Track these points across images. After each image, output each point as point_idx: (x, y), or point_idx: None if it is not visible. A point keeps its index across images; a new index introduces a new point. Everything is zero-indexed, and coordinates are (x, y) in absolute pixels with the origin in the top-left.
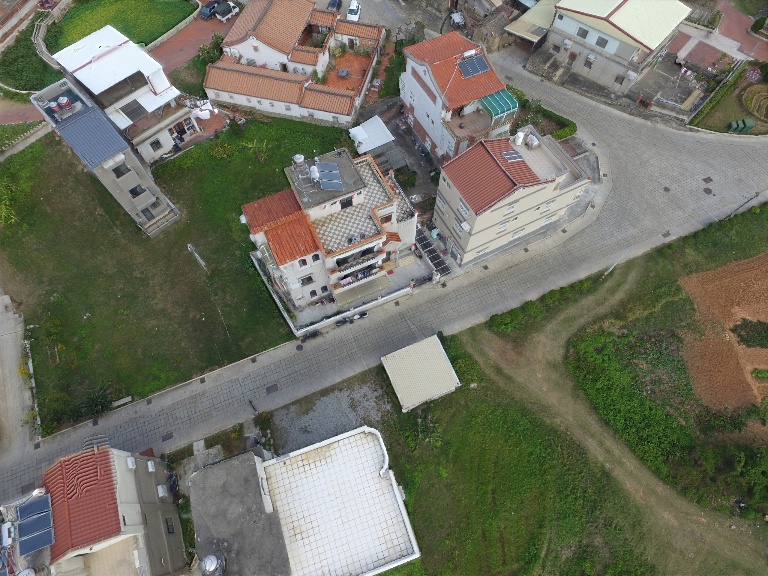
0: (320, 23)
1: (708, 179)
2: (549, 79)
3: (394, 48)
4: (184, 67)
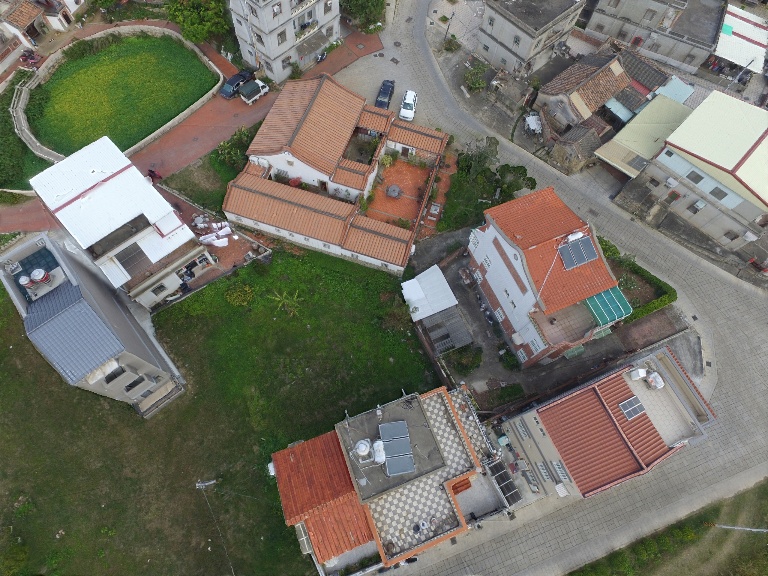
0: (370, 127)
1: None
2: (641, 218)
3: (456, 158)
4: (198, 165)
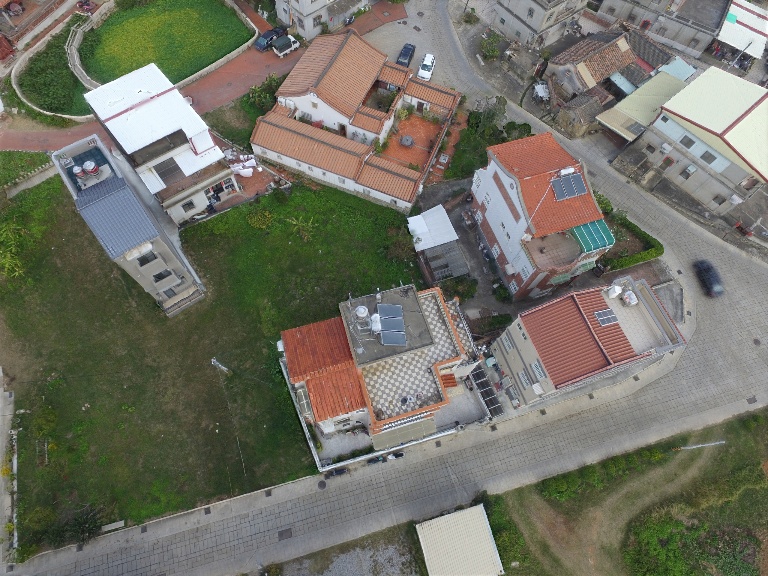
0: (390, 81)
1: None
2: (637, 182)
3: (467, 117)
4: (230, 107)
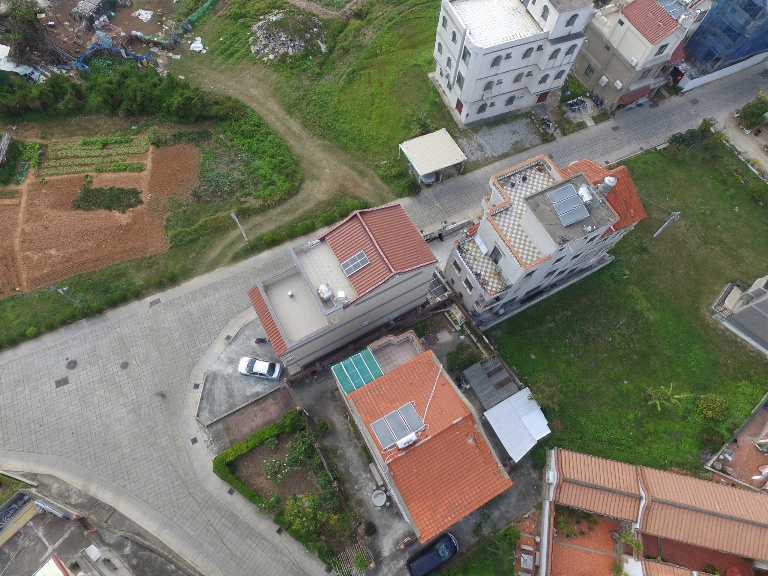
0: None
1: (61, 384)
2: None
3: None
4: None
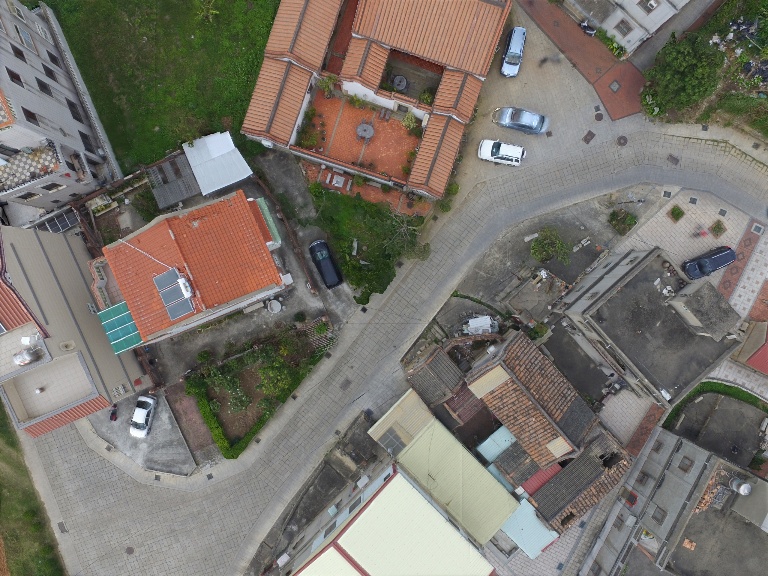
0: (442, 87)
1: None
2: None
3: None
4: None
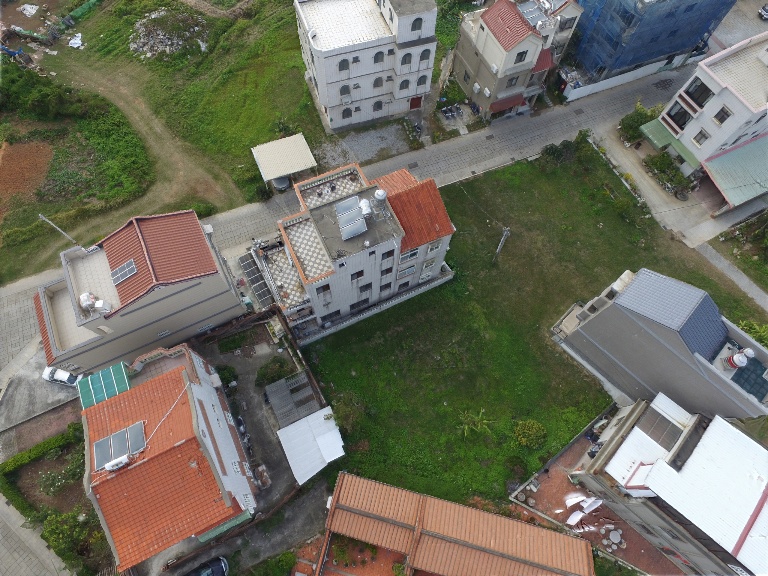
0: None
1: None
2: None
3: None
4: None
